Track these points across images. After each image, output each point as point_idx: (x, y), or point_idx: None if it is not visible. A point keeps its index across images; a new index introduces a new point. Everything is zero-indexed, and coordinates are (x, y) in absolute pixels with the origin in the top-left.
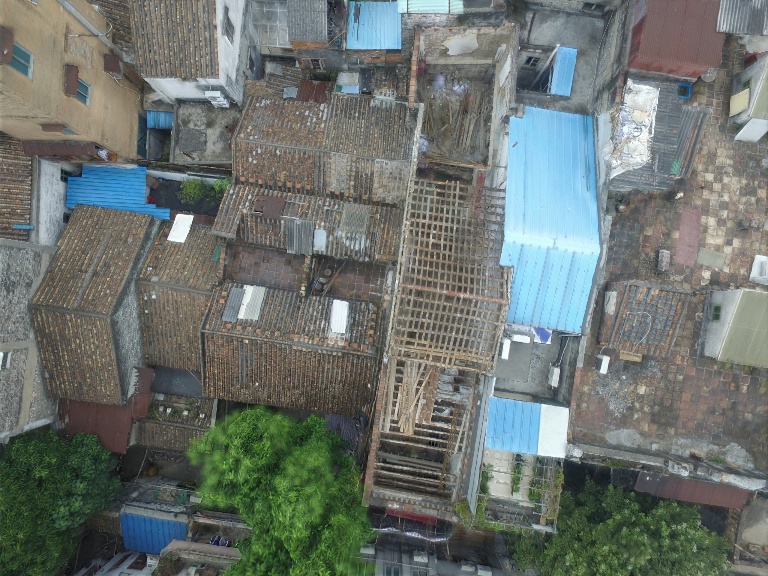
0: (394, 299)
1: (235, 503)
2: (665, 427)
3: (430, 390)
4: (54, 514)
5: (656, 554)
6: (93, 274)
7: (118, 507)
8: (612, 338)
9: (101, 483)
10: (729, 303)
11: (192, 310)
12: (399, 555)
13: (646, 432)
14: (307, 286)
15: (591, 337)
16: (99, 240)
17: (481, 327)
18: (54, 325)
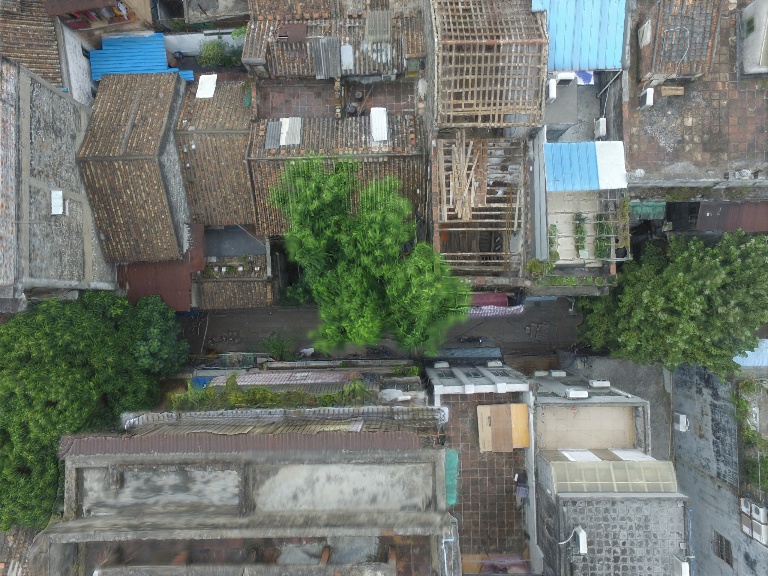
0: (436, 59)
1: (313, 289)
2: (717, 154)
3: (480, 172)
4: (135, 353)
5: (729, 279)
6: (132, 126)
7: (190, 370)
8: (654, 61)
9: (172, 339)
10: (762, 7)
11: (232, 155)
12: (473, 367)
13: (700, 162)
14: (341, 110)
15: (631, 79)
16: (131, 100)
17: (524, 74)
18: (103, 177)
